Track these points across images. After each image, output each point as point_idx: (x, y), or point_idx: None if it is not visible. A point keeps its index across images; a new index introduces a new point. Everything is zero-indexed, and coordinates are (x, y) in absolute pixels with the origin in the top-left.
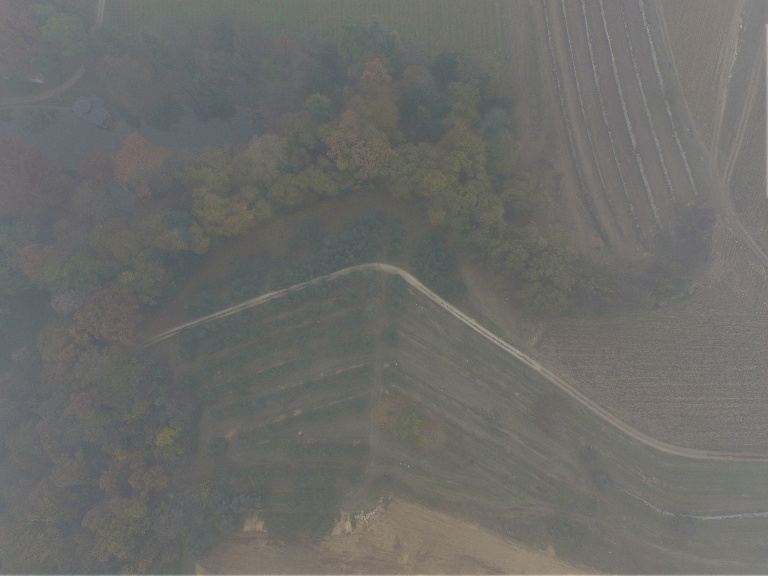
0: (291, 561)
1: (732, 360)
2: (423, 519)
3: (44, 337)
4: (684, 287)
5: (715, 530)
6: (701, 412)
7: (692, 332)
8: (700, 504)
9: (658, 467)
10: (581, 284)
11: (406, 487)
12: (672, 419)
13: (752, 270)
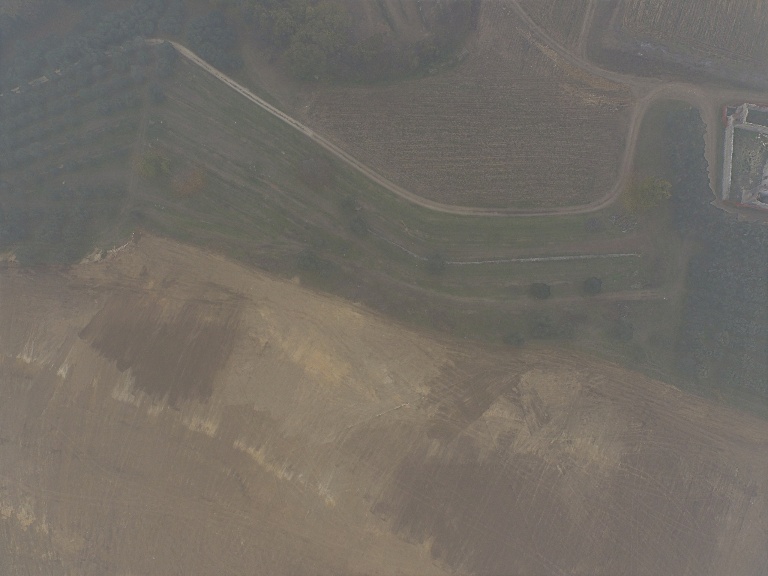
0: (40, 287)
1: (499, 121)
2: (171, 251)
3: None
4: (453, 54)
5: (471, 274)
6: (467, 171)
7: (461, 97)
8: (460, 252)
9: (422, 221)
10: (348, 49)
11: (159, 225)
12: (439, 178)
13: (519, 35)
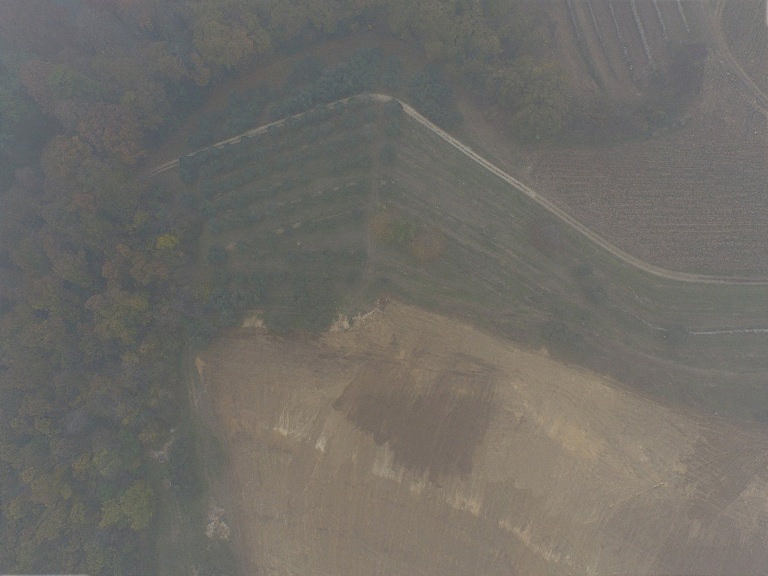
0: (290, 355)
1: (723, 188)
2: (419, 319)
3: (47, 151)
4: (676, 118)
5: (706, 344)
6: (693, 237)
7: (684, 161)
8: (692, 321)
9: (650, 288)
10: (575, 111)
11: (403, 291)
12: (664, 244)
13: (743, 101)
